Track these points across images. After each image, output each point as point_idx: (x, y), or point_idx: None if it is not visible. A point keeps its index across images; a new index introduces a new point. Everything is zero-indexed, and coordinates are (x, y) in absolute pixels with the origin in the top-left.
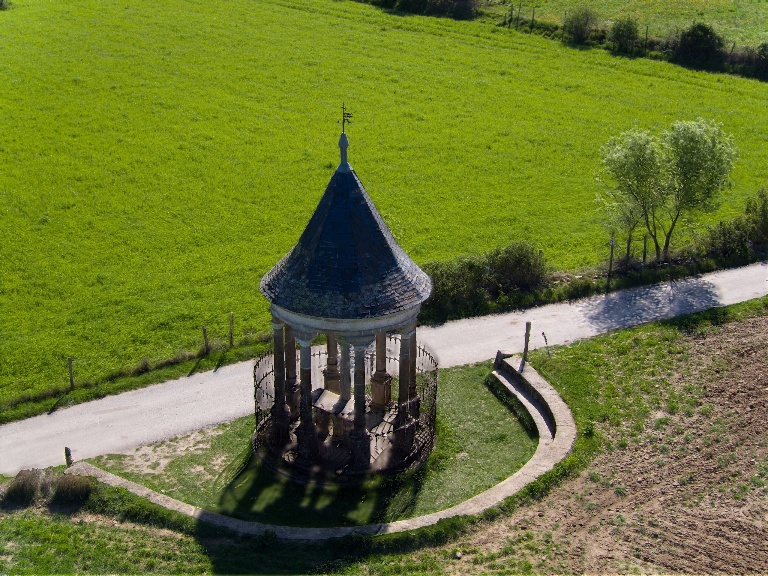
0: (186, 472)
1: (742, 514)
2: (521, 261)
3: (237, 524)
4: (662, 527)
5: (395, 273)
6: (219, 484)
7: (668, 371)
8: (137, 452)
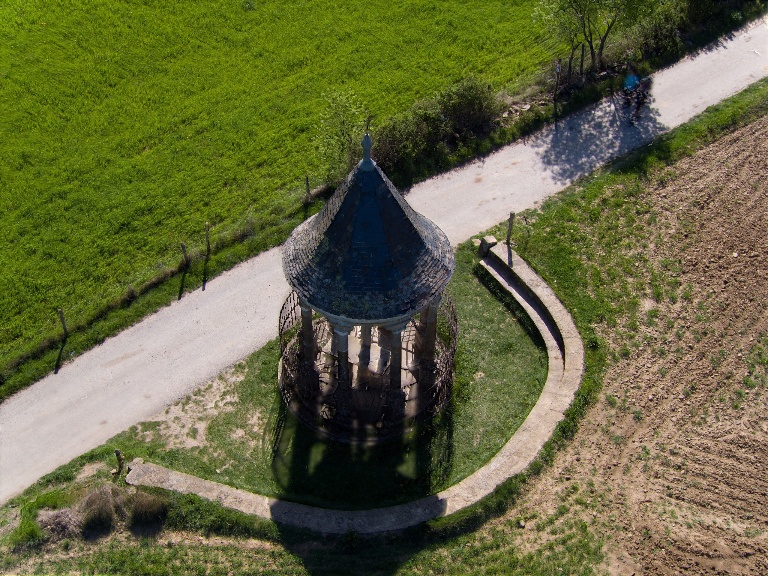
0: (229, 440)
1: (744, 426)
2: (473, 102)
3: (317, 522)
4: (682, 455)
5: (425, 256)
6: (268, 453)
7: (642, 242)
8: (168, 415)
